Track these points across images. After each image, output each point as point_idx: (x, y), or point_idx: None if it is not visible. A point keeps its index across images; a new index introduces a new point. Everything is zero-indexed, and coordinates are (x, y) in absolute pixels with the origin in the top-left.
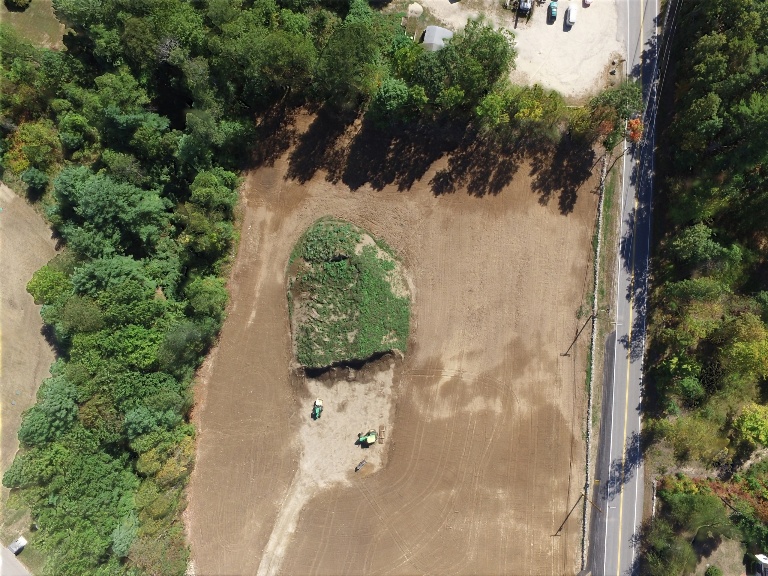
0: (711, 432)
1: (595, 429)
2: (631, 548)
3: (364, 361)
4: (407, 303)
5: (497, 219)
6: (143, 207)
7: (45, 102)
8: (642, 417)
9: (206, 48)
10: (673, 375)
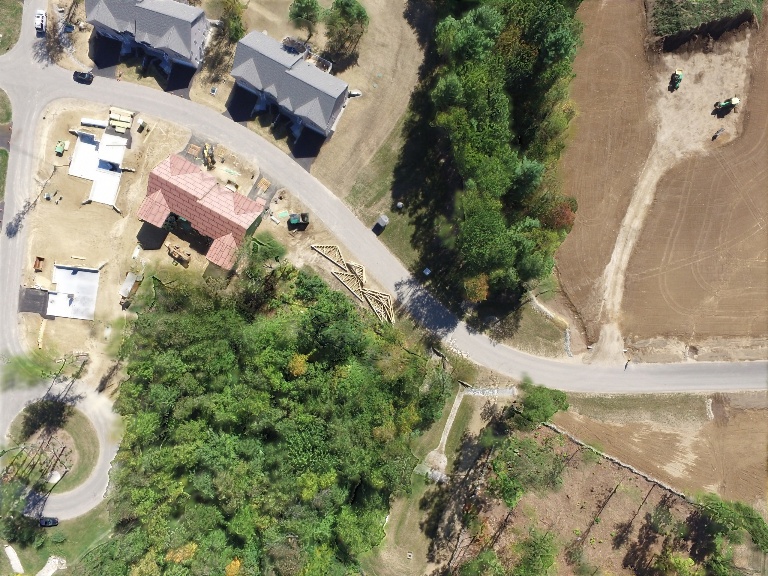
0: None
1: None
2: None
3: (724, 29)
4: None
5: None
6: None
7: None
8: None
9: None
10: None
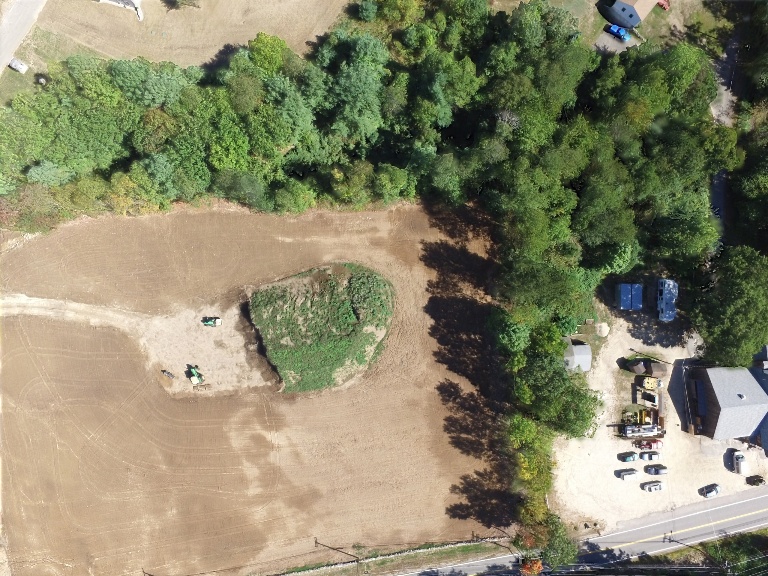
0: None
1: None
2: None
3: None
4: (330, 384)
5: (428, 450)
6: (362, 122)
7: (440, 6)
8: None
9: (519, 152)
10: None
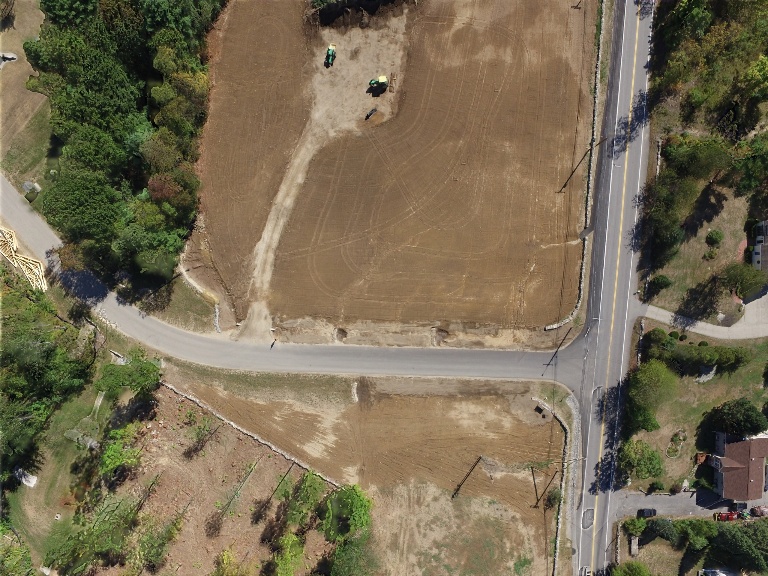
0: (717, 94)
1: (603, 85)
2: (634, 208)
3: (378, 3)
4: None
5: None
6: None
7: None
8: (650, 76)
9: None
10: (682, 18)
